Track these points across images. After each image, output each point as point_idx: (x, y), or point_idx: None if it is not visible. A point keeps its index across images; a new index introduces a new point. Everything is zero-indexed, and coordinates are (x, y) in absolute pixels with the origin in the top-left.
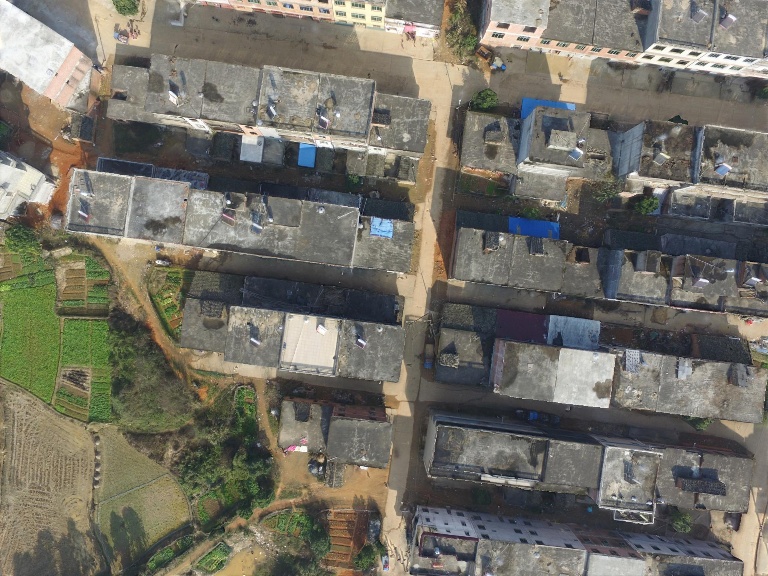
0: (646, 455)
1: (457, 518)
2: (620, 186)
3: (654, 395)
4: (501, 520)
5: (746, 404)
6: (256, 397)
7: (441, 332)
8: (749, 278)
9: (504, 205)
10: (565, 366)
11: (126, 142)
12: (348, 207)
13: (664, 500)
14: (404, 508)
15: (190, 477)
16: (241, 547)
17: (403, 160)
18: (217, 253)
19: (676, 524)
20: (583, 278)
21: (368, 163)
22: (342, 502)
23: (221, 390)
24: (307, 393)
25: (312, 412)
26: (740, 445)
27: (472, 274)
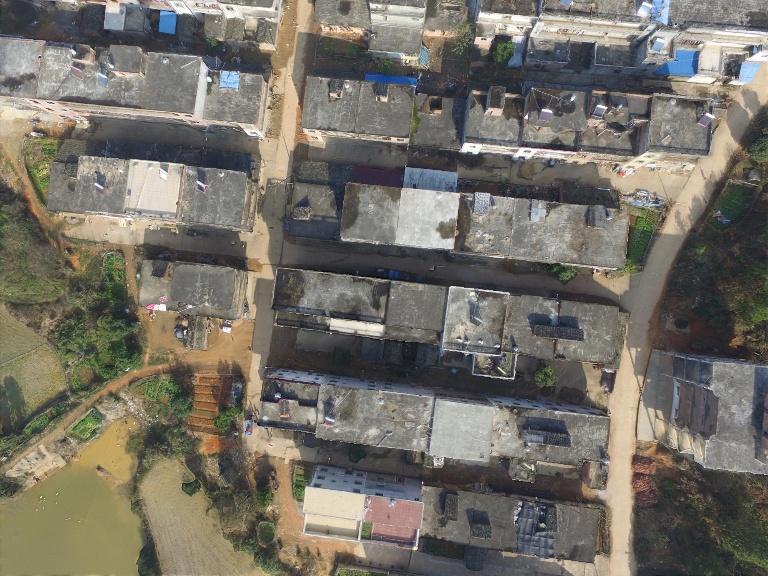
0: (493, 296)
1: (314, 376)
2: (470, 31)
3: (506, 239)
4: (361, 380)
5: (607, 248)
6: (125, 263)
7: (294, 187)
8: (596, 107)
9: (365, 66)
10: (407, 206)
11: (6, 23)
12: (191, 56)
13: (521, 350)
14: (268, 373)
15: (63, 343)
16: (114, 416)
17: (261, 23)
18: (88, 124)
19: (537, 377)
20: (438, 128)
21: (227, 28)
22: (207, 367)
23: (92, 257)
24: (171, 257)
25: (170, 270)
26: (615, 303)
27: (318, 122)
